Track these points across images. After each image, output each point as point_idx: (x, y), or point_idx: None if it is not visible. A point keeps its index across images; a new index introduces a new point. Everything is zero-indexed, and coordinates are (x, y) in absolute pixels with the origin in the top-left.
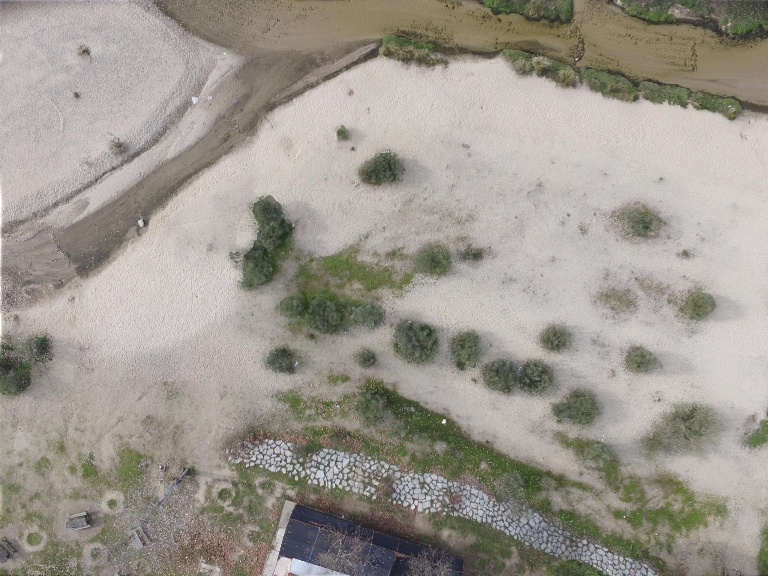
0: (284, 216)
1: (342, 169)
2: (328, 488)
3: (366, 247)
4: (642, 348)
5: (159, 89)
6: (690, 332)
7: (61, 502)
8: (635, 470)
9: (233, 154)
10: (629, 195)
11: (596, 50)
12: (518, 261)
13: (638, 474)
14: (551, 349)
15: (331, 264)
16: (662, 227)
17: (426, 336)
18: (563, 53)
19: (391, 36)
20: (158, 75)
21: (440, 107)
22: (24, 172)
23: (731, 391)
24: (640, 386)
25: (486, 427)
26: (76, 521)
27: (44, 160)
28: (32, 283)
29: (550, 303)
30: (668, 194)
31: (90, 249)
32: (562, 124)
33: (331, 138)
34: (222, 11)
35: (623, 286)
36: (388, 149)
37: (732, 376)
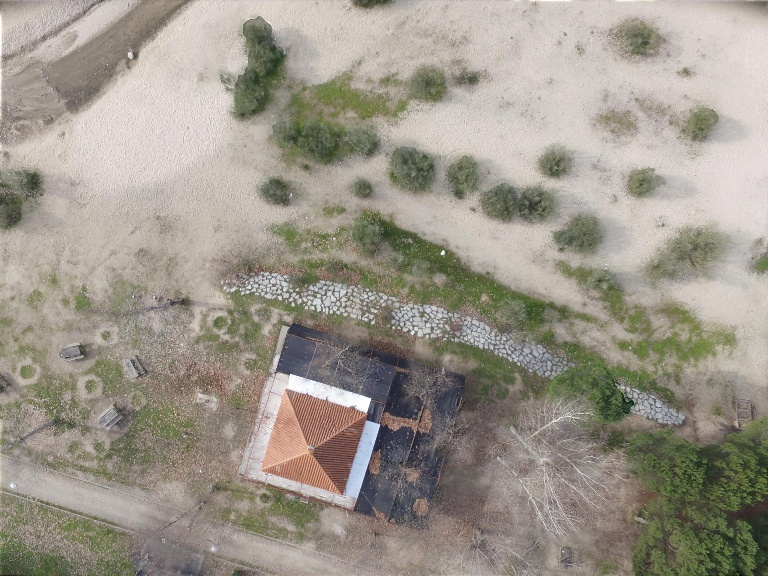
0: (275, 43)
1: None
2: (325, 314)
3: (359, 74)
4: None
5: None
6: (693, 154)
7: (54, 334)
8: (640, 299)
9: None
10: (627, 11)
11: None
12: (515, 84)
13: (643, 303)
14: (551, 175)
15: (324, 93)
16: (661, 44)
17: (422, 157)
18: None
19: None
20: None
21: None
22: (11, 3)
23: (737, 214)
24: (643, 211)
25: (486, 258)
26: (69, 350)
27: None
28: (22, 119)
29: (549, 127)
30: (667, 10)
31: (79, 83)
32: None
33: None
34: None
35: (623, 107)
36: None
37: (737, 199)
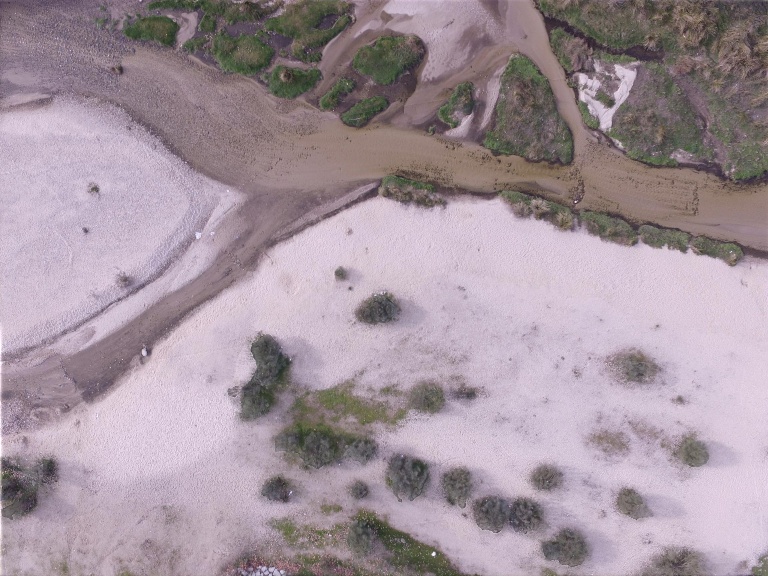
0: (282, 351)
1: (339, 308)
2: None
3: (361, 382)
4: (634, 491)
5: (164, 226)
6: (683, 476)
7: None
8: None
9: (234, 288)
10: (625, 341)
11: (596, 193)
12: (511, 401)
13: None
14: (542, 488)
15: (326, 397)
16: (657, 373)
17: (417, 476)
18: (562, 195)
19: (391, 176)
20: (163, 212)
21: (437, 249)
22: (34, 303)
23: (723, 536)
24: (631, 528)
25: (475, 561)
26: None
27: (53, 291)
28: (40, 406)
29: (542, 443)
30: (664, 341)
31: (95, 375)
32: (559, 269)
33: (329, 277)
34: (226, 150)
35: (616, 429)
36: (385, 289)
37: (725, 521)
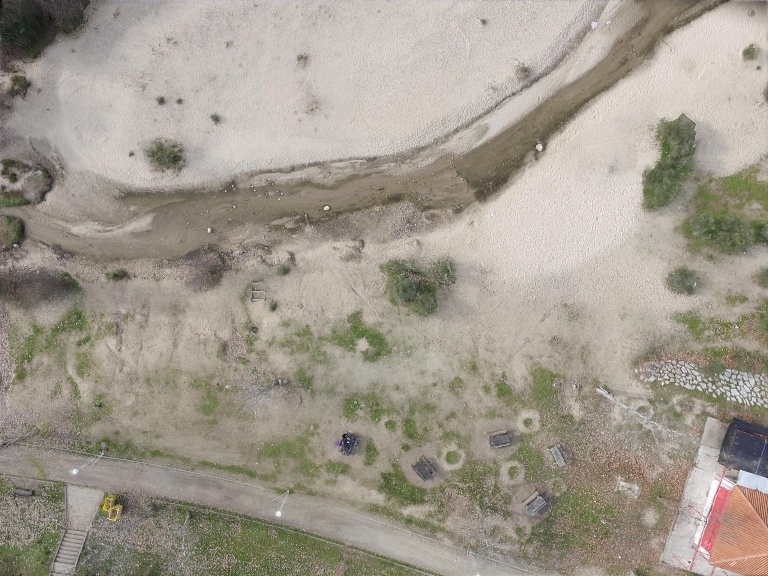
0: None
1: (747, 88)
2: (747, 405)
3: (766, 167)
4: None
5: (563, 14)
6: None
7: (477, 421)
8: None
9: (631, 77)
10: None
11: None
12: None
13: None
14: None
15: (730, 185)
16: None
17: None
18: None
19: None
20: (563, 0)
21: None
22: (431, 98)
23: None
24: None
25: None
26: (500, 438)
27: (450, 86)
28: (432, 208)
29: None
30: None
31: (488, 174)
32: None
33: (735, 58)
34: None
35: None
36: None
37: None
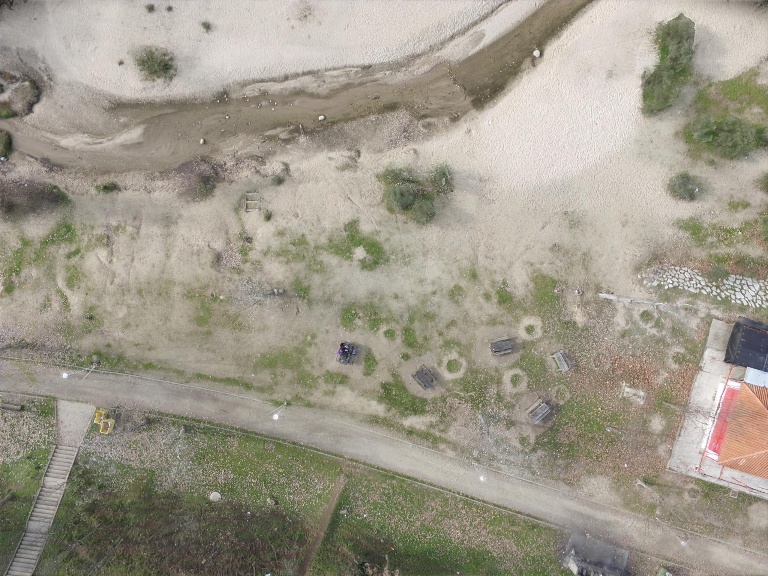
0: None
1: None
2: (753, 307)
3: (766, 69)
4: None
5: None
6: None
7: (478, 329)
8: None
9: None
10: None
11: None
12: None
13: None
14: None
15: (730, 88)
16: None
17: None
18: None
19: None
20: None
21: None
22: (426, 3)
23: None
24: None
25: None
26: (501, 344)
27: None
28: (428, 117)
29: None
30: None
31: (485, 81)
32: None
33: None
34: None
35: None
36: None
37: None
